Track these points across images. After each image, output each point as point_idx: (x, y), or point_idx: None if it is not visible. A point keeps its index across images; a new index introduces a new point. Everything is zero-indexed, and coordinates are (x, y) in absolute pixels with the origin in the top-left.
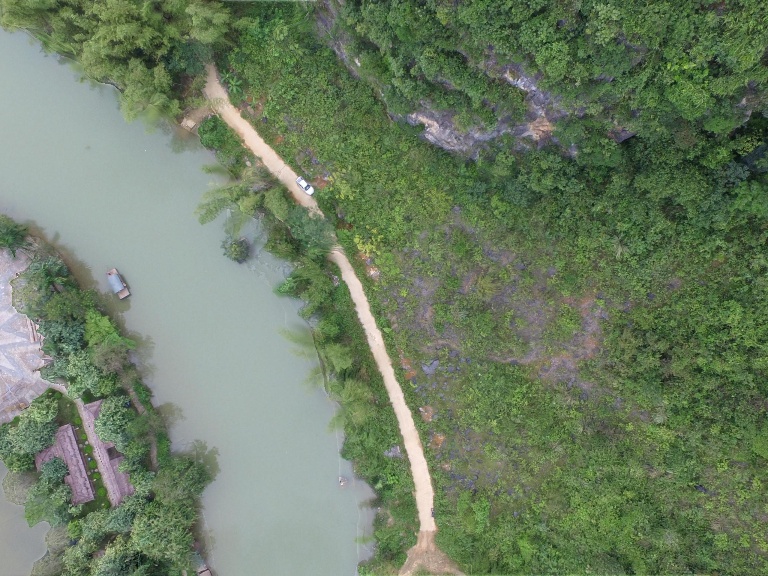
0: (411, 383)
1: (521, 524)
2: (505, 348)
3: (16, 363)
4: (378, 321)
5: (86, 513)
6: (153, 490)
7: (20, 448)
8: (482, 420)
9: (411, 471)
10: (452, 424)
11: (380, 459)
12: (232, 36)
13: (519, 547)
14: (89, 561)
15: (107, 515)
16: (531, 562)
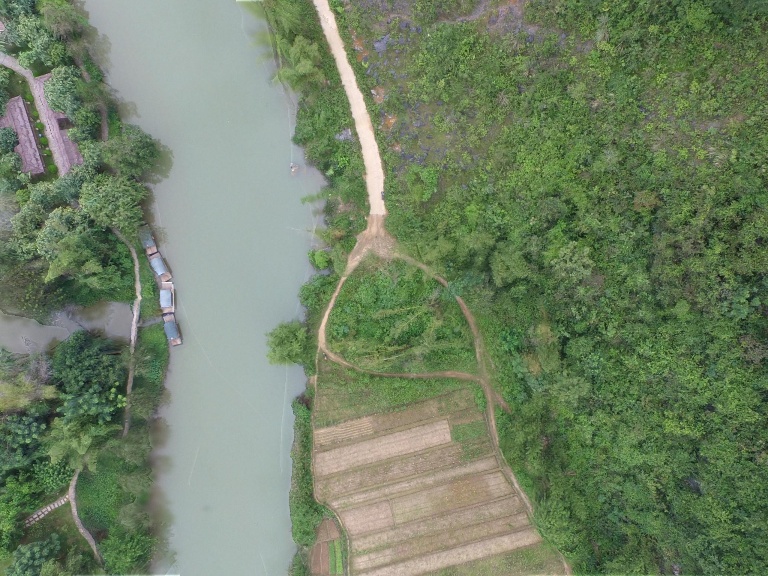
0: (363, 62)
1: (469, 192)
2: (454, 2)
3: None
4: (331, 1)
5: (35, 182)
6: (101, 154)
7: None
8: (431, 86)
9: (362, 154)
10: (402, 96)
11: (331, 141)
12: None
13: (467, 217)
14: (37, 230)
15: None
16: (477, 226)
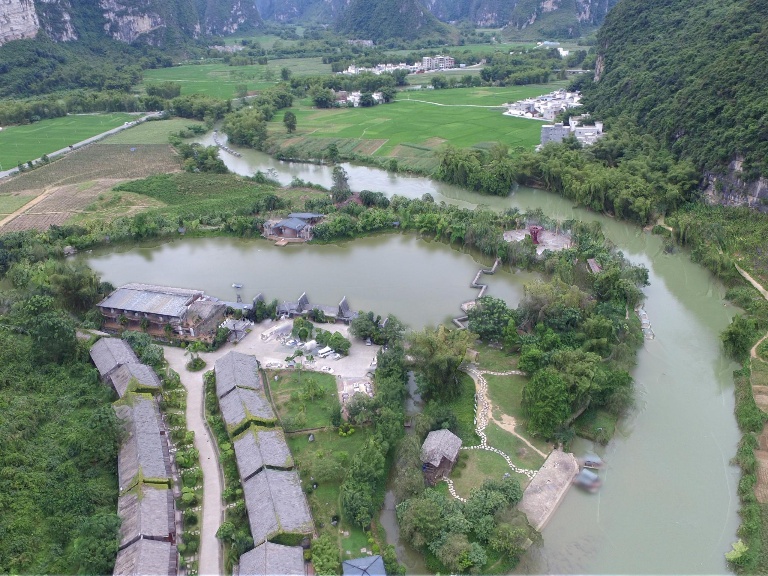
0: (767, 281)
1: None
2: None
3: None
4: None
5: None
6: None
7: None
8: None
9: None
10: None
11: None
12: (679, 201)
13: None
14: None
15: None
16: None
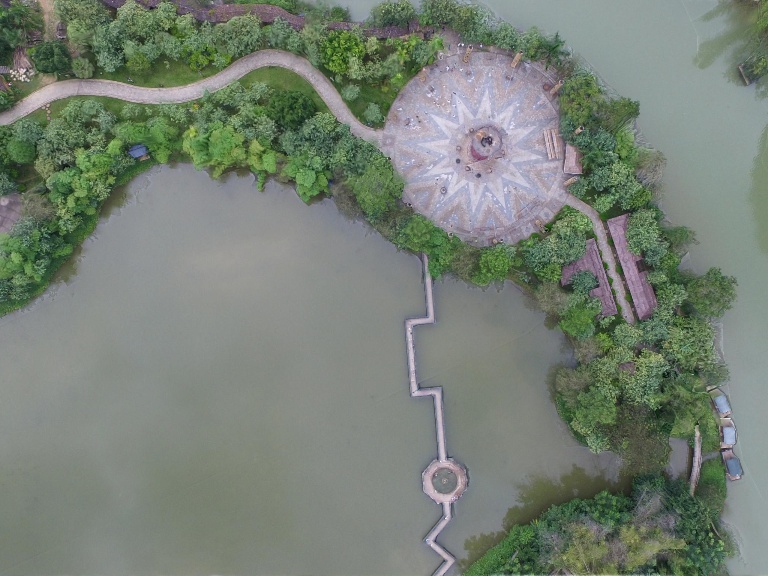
0: None
1: None
2: None
3: (531, 180)
4: None
5: (615, 325)
6: (691, 300)
7: (558, 257)
8: None
9: None
10: None
11: None
12: None
13: None
14: (617, 373)
15: (637, 327)
16: None
